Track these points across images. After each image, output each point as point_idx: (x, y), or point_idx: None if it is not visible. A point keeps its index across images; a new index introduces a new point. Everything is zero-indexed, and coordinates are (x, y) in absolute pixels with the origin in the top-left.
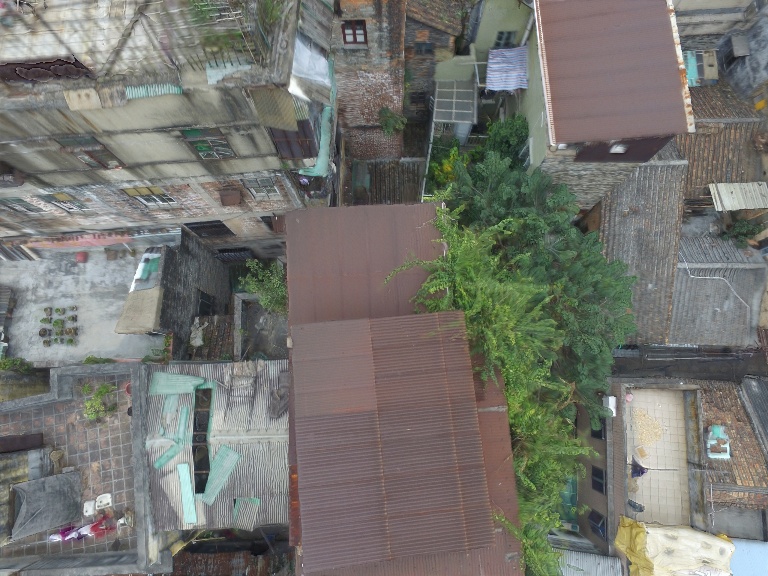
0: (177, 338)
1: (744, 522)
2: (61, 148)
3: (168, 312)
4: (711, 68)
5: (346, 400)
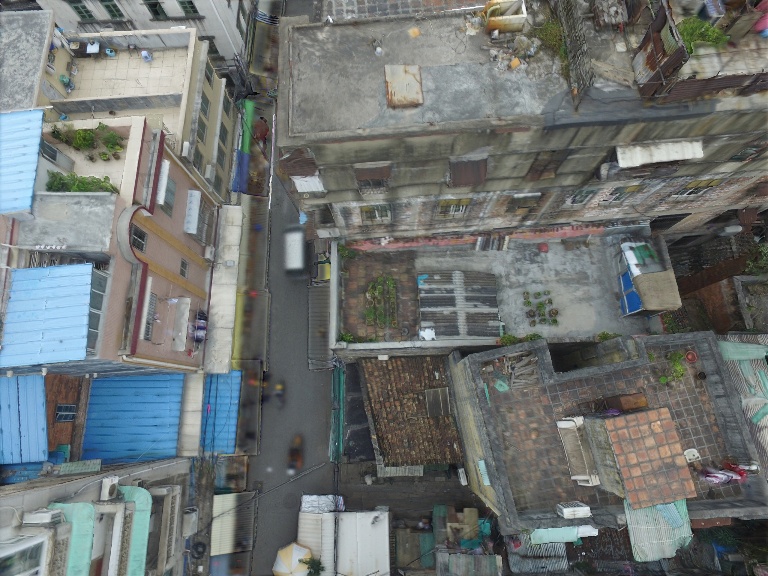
0: None
1: None
2: (751, 141)
3: None
4: None
5: None
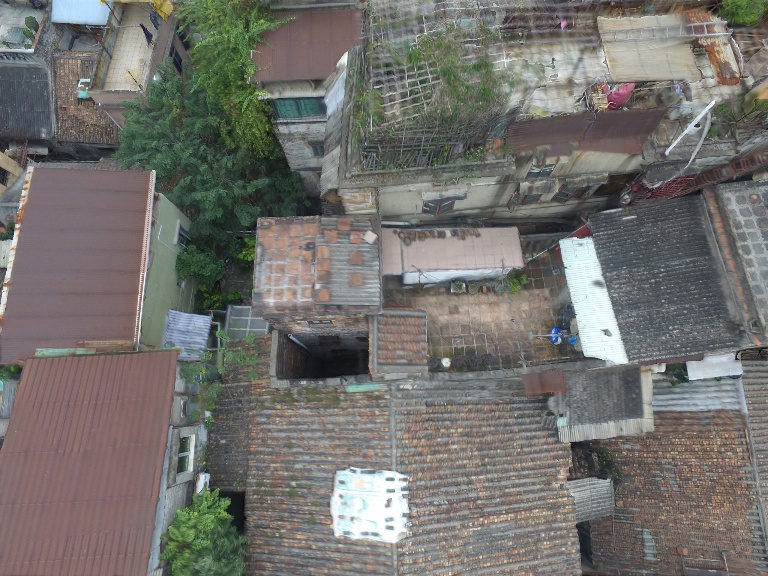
0: None
1: (84, 50)
2: None
3: None
4: None
5: None
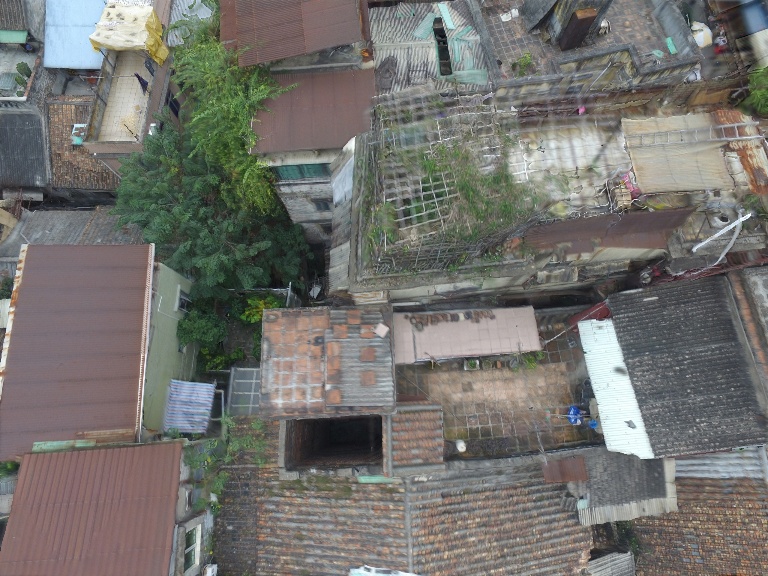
0: None
1: (78, 93)
2: None
3: None
4: None
5: (322, 5)
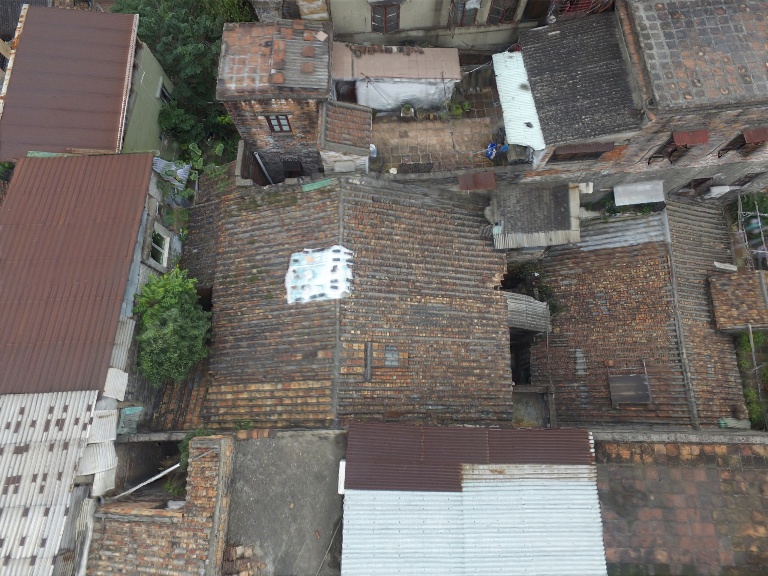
0: None
1: None
2: None
3: None
4: None
5: None
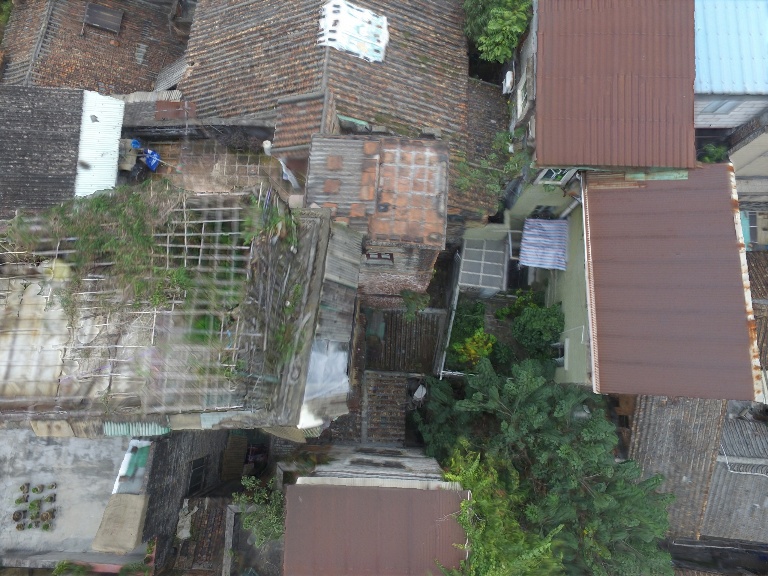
0: (162, 538)
1: None
2: None
3: (153, 517)
4: (765, 232)
5: None
